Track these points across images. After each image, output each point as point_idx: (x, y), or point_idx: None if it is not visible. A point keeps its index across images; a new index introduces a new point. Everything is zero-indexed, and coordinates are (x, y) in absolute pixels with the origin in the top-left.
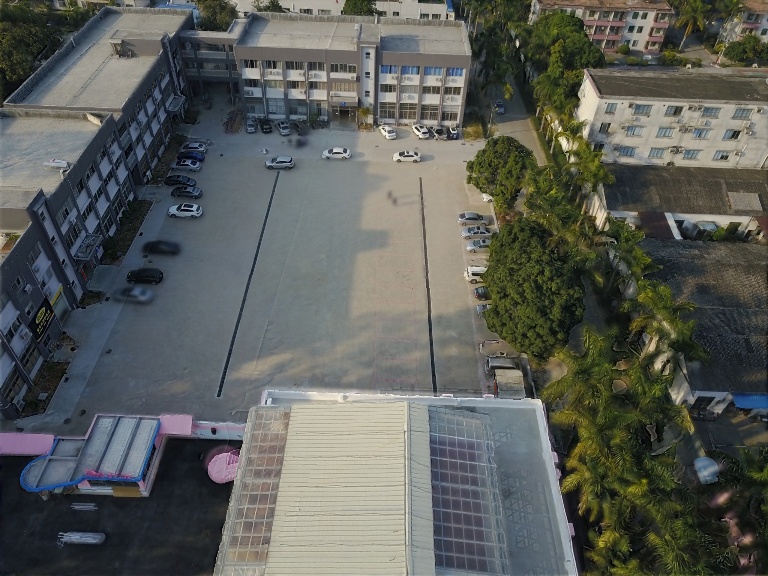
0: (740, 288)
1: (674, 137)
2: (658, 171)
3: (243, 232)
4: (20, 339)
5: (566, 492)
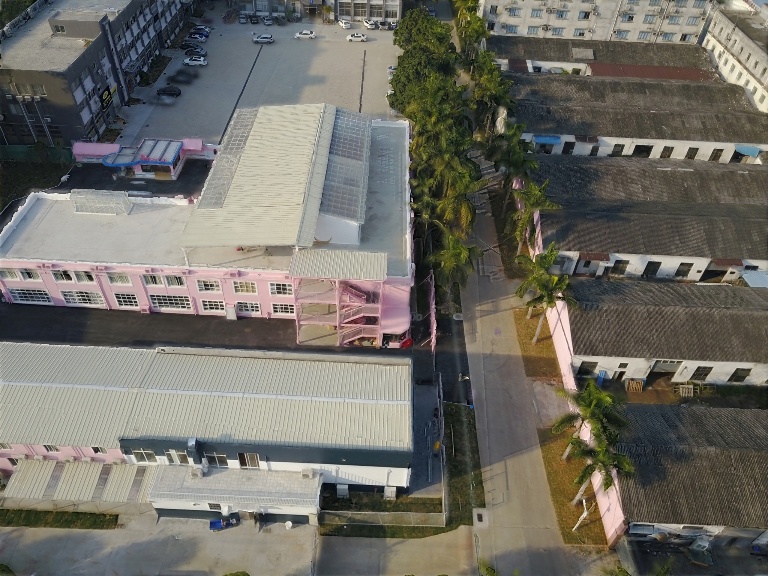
0: (560, 92)
1: (544, 17)
2: (528, 37)
3: (236, 75)
4: (94, 103)
5: (411, 149)
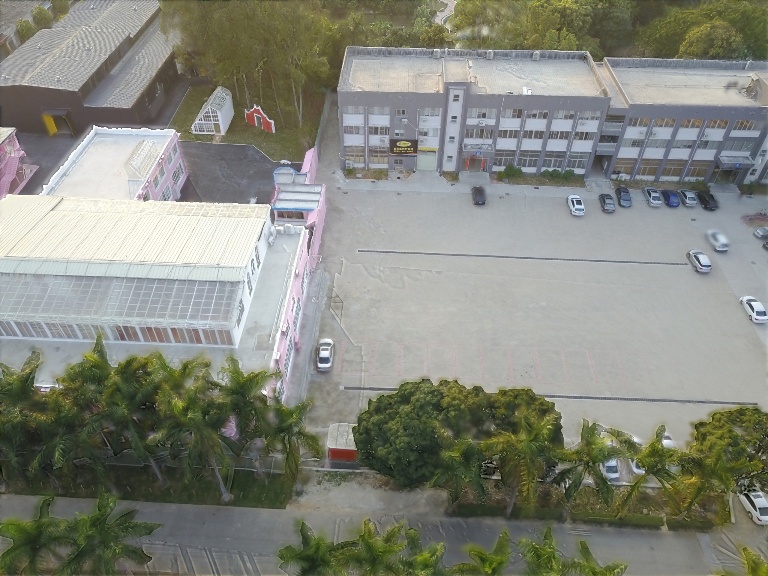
0: None
1: None
2: None
3: (564, 246)
4: None
5: None
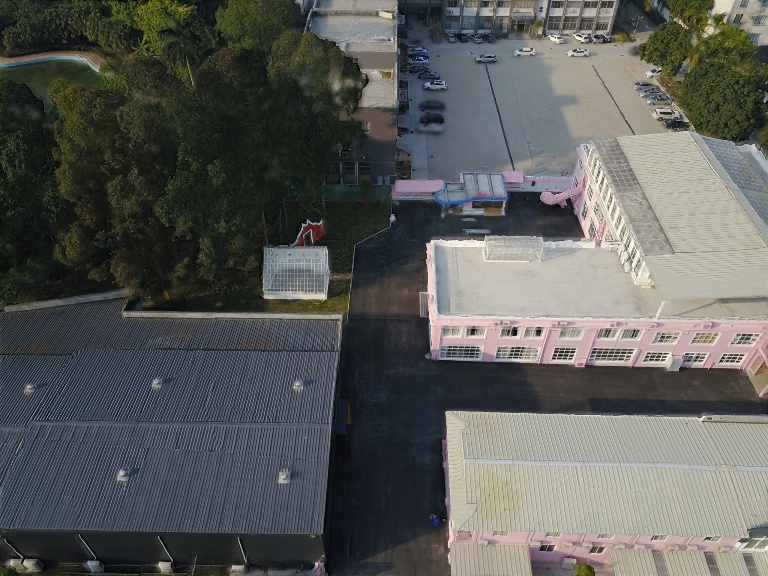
0: None
1: None
2: None
3: (481, 98)
4: None
5: None
